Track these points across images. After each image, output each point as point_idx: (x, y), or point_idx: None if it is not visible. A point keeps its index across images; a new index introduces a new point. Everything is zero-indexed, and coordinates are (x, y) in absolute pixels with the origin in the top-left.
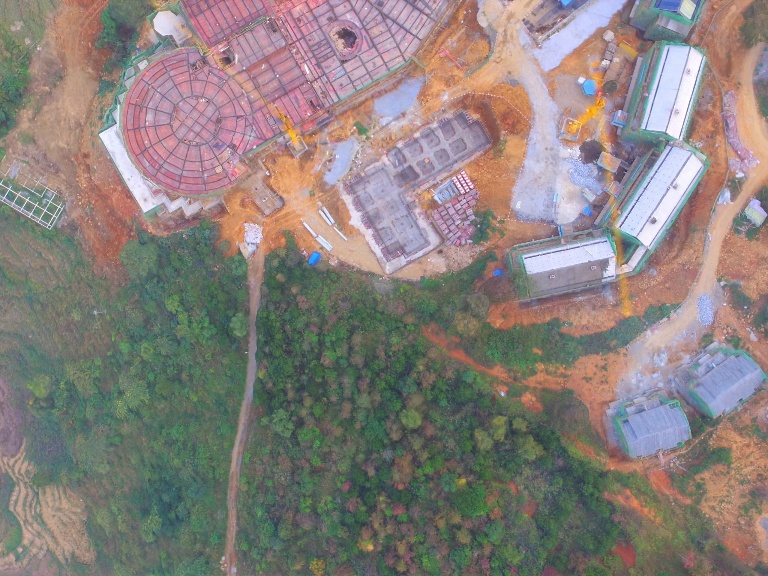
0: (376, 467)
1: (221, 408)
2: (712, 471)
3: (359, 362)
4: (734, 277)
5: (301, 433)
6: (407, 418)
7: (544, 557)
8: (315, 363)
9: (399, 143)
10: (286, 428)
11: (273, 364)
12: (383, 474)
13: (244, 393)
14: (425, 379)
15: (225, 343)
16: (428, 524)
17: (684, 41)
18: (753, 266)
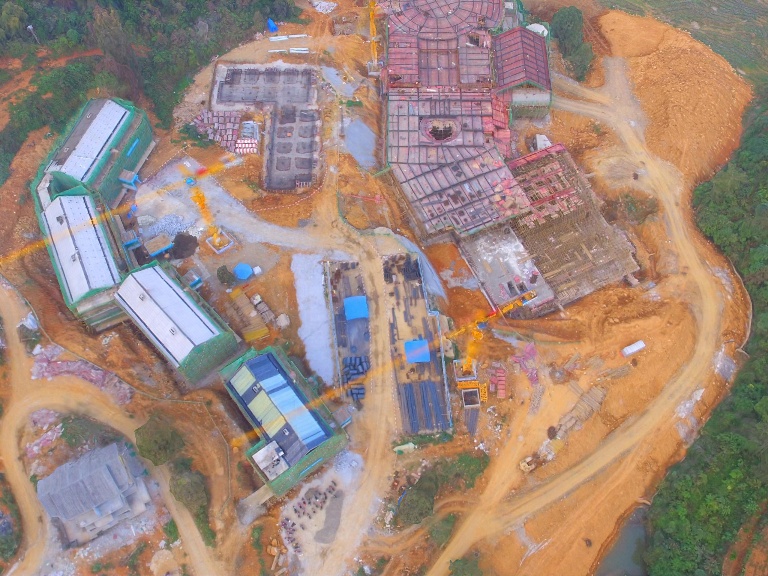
0: None
1: None
2: None
3: None
4: None
5: None
6: None
7: None
8: None
9: (321, 123)
10: None
11: None
12: None
13: None
14: None
15: None
16: None
17: None
18: None
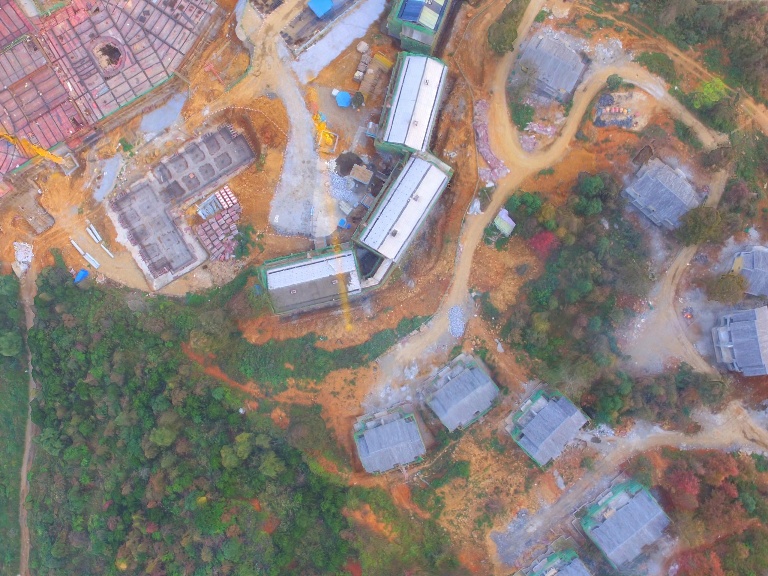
0: (132, 485)
1: (10, 426)
2: (451, 484)
3: (116, 380)
4: (484, 288)
5: (66, 452)
6: (154, 436)
7: (275, 575)
8: (81, 381)
9: (164, 159)
10: (53, 447)
11: (43, 383)
12: (136, 492)
13: (28, 411)
14: (174, 396)
15: (1, 362)
16: (175, 542)
17: (440, 50)
18: (499, 277)
